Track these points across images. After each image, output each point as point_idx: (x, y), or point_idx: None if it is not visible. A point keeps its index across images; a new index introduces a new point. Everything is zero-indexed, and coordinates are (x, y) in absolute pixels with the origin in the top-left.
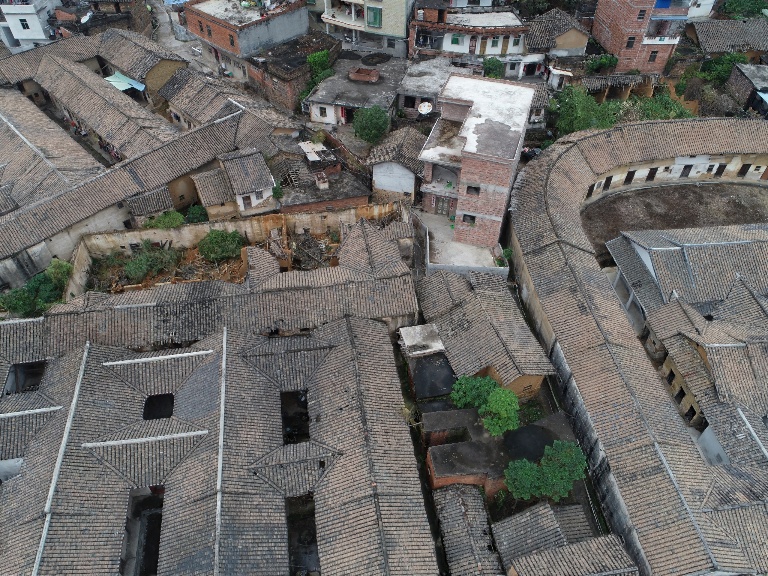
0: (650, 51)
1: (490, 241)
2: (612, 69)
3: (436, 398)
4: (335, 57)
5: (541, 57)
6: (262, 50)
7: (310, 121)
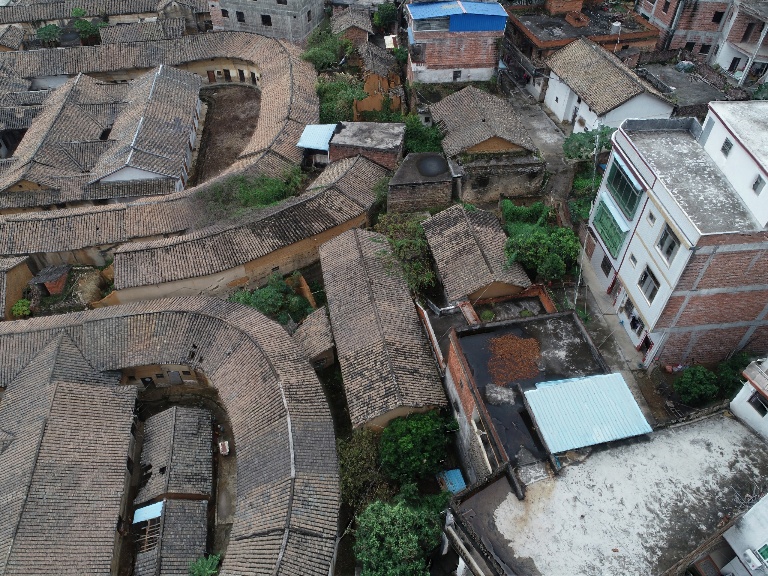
0: None
1: None
2: None
3: None
4: None
5: None
6: None
7: None
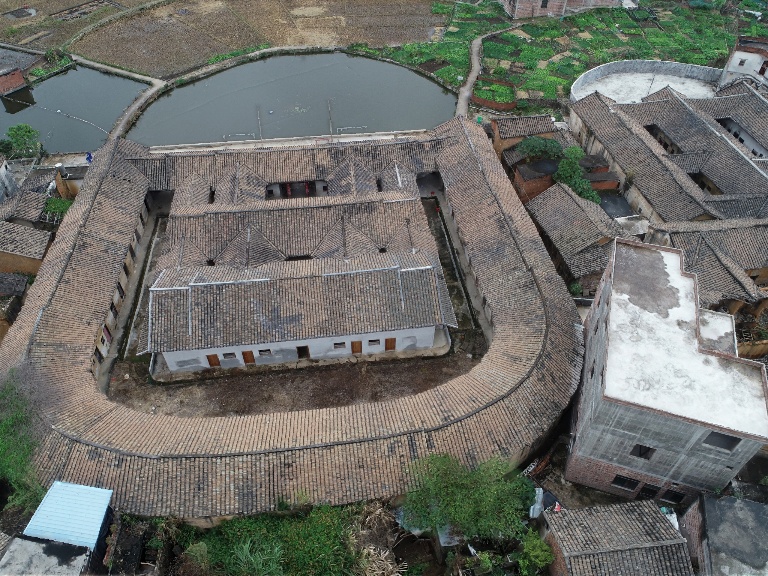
0: None
1: None
2: None
3: None
4: None
5: None
6: None
7: None
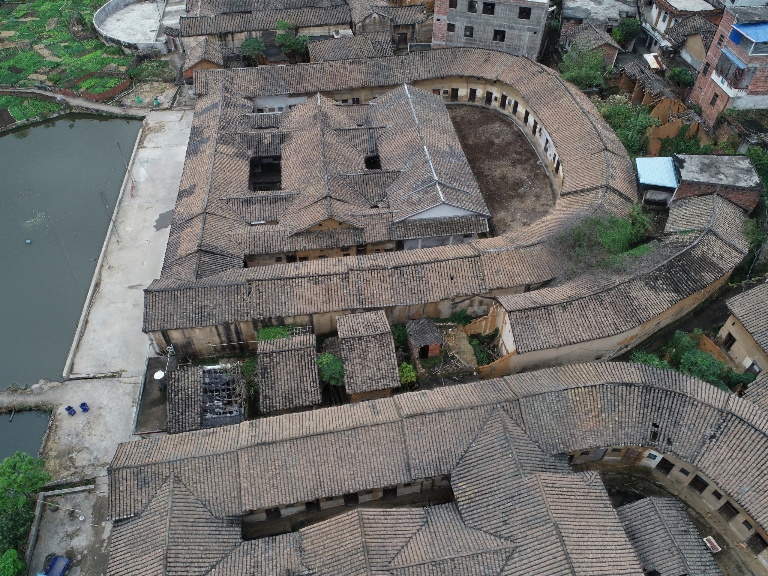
0: (714, 91)
1: None
2: (689, 92)
3: None
4: None
5: None
6: None
7: None
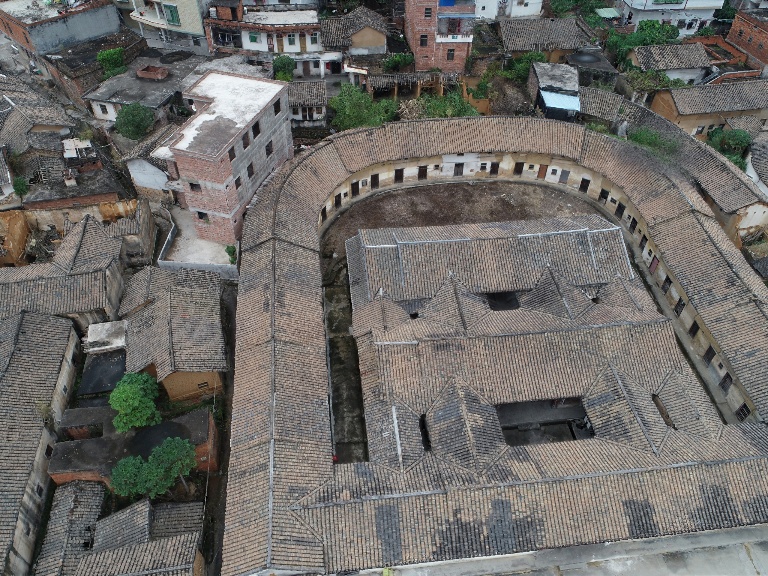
0: (446, 49)
1: (229, 238)
2: (412, 67)
3: (98, 394)
4: (136, 55)
5: (340, 55)
6: (62, 48)
7: (96, 118)
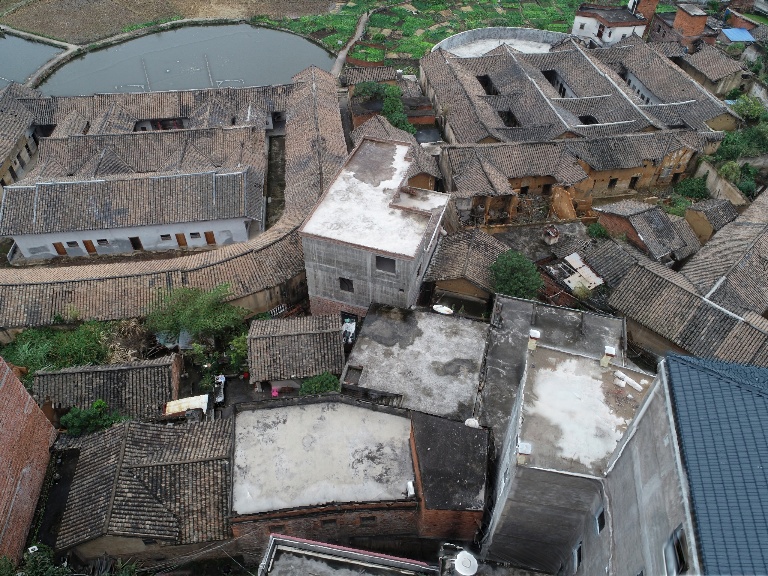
0: None
1: None
2: None
3: None
4: None
5: None
6: None
7: None
